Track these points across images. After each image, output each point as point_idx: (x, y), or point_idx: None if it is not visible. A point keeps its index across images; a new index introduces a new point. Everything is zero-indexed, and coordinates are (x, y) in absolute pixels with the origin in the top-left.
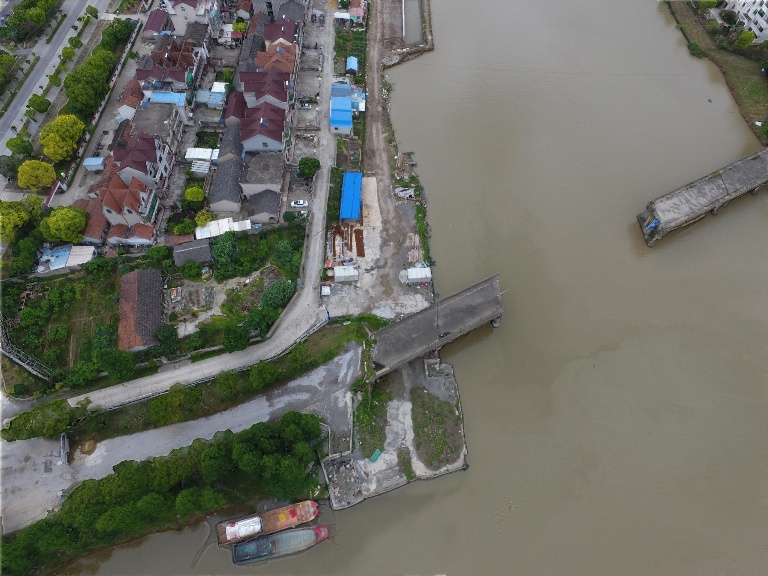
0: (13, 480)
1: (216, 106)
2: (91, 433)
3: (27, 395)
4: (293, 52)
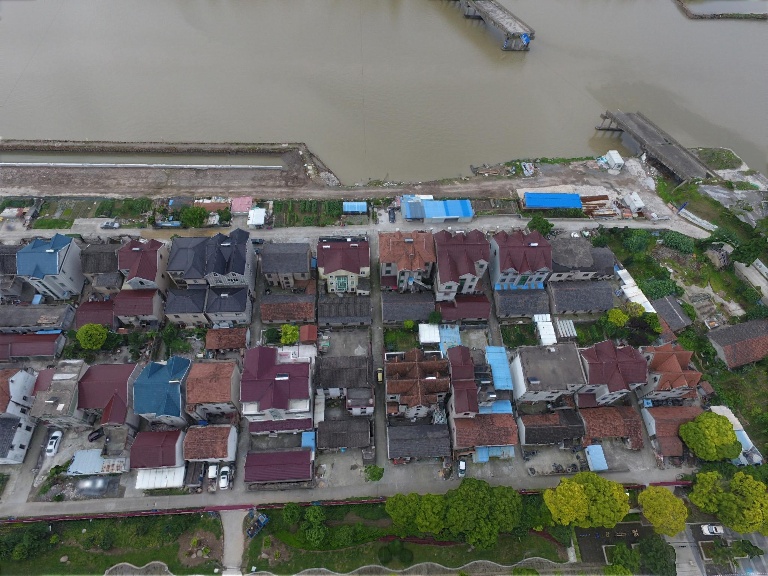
0: None
1: None
2: None
3: None
4: None
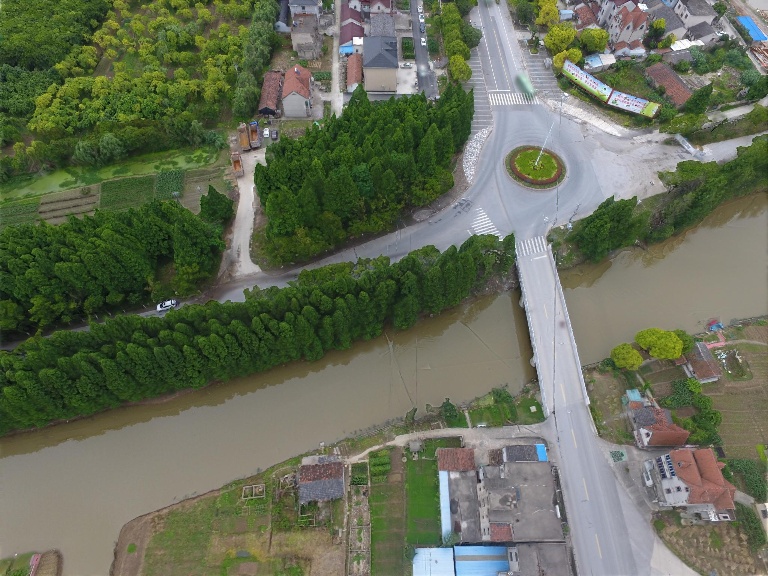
0: (666, 163)
1: None
2: (695, 141)
3: (637, 126)
4: None
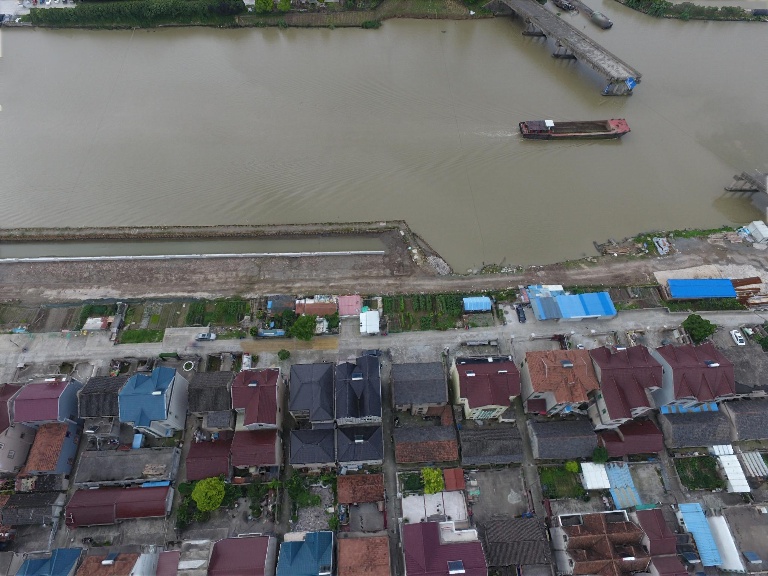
0: None
1: None
2: None
3: None
4: (545, 353)
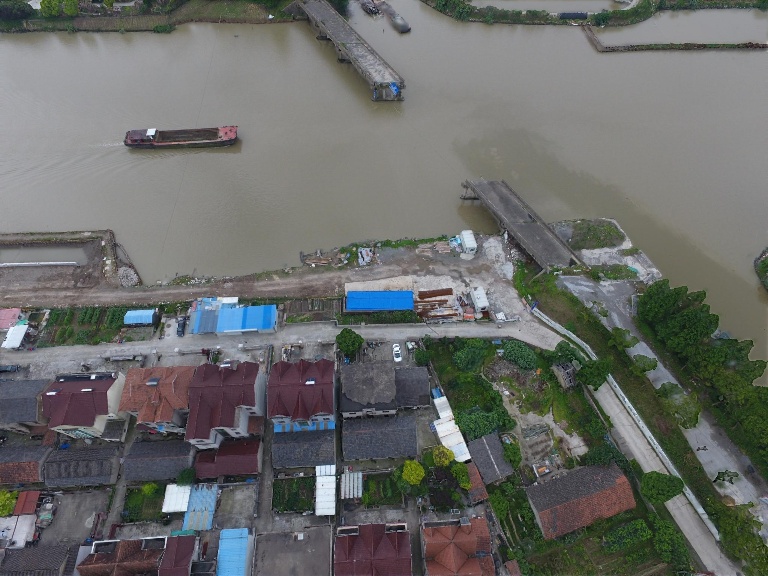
0: None
1: (216, 499)
2: None
3: None
4: None
